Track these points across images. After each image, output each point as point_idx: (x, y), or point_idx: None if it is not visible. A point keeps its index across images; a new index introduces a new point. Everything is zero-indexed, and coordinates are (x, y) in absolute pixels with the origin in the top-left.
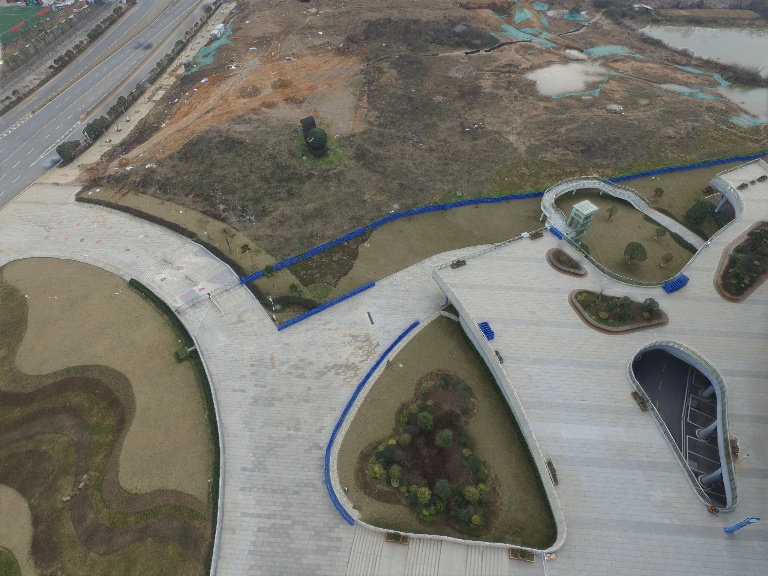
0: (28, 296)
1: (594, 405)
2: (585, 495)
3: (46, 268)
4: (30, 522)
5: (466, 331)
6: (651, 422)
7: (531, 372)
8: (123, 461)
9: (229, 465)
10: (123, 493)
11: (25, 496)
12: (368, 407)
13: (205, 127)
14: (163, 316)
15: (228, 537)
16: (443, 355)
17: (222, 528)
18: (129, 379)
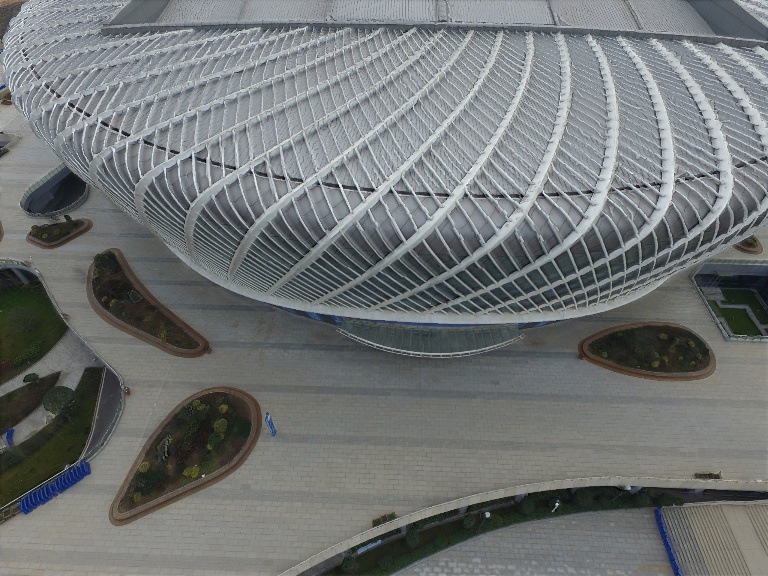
0: None
1: None
2: None
3: None
4: None
5: None
6: None
7: None
8: None
9: None
10: None
11: None
12: None
13: (16, 1)
14: None
15: None
16: None
17: None
18: None
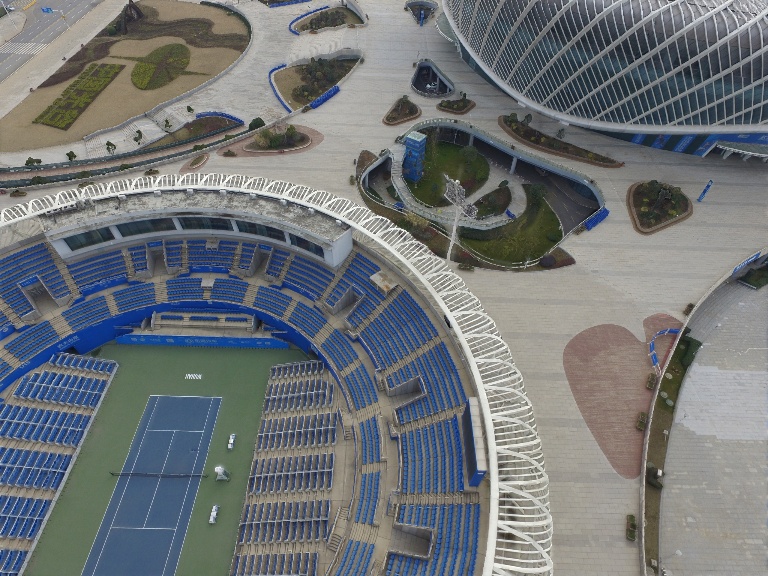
0: (155, 7)
1: (389, 10)
2: (377, 21)
3: (159, 2)
4: None
5: (348, 7)
6: None
7: (368, 5)
8: (213, 30)
9: (254, 27)
10: (216, 34)
11: None
12: (306, 19)
13: None
14: None
15: (256, 36)
16: None
17: (253, 35)
18: (209, 19)
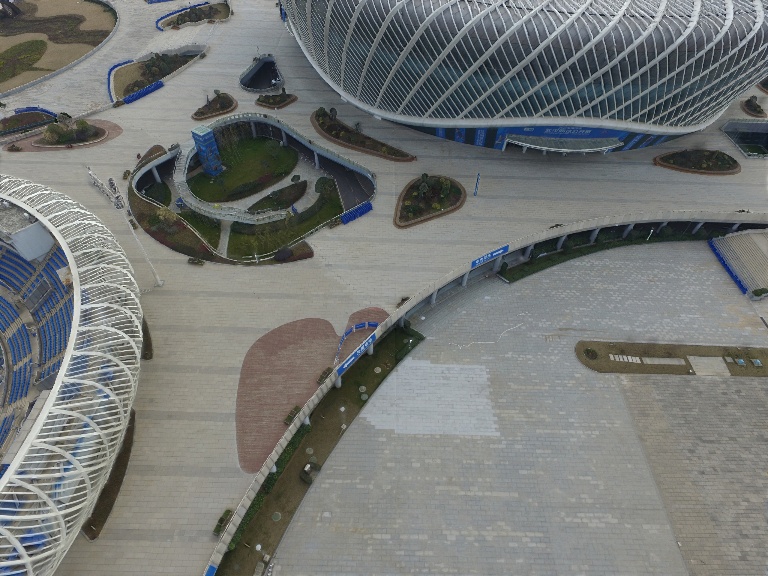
0: (37, 4)
1: None
2: None
3: None
4: (47, 36)
5: None
6: (278, 8)
7: None
8: None
9: None
10: (81, 30)
11: (44, 33)
12: None
13: None
14: (99, 5)
15: (118, 32)
16: (215, 7)
17: (116, 31)
18: None
